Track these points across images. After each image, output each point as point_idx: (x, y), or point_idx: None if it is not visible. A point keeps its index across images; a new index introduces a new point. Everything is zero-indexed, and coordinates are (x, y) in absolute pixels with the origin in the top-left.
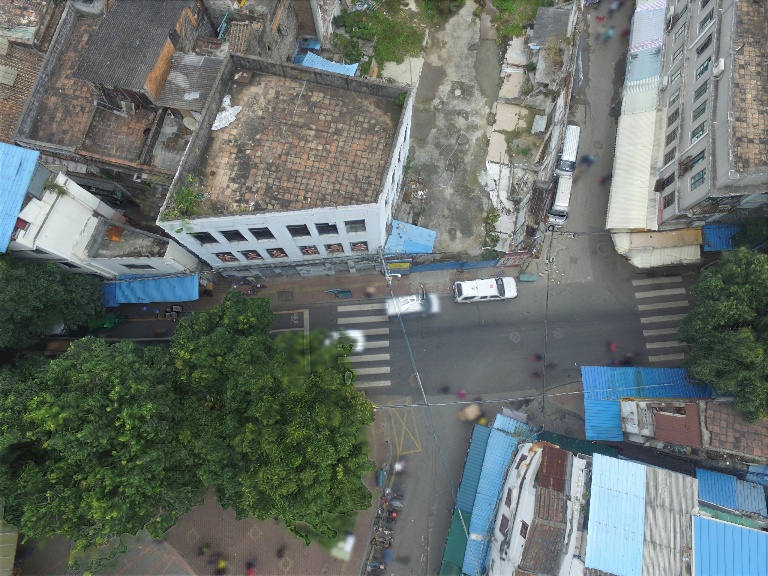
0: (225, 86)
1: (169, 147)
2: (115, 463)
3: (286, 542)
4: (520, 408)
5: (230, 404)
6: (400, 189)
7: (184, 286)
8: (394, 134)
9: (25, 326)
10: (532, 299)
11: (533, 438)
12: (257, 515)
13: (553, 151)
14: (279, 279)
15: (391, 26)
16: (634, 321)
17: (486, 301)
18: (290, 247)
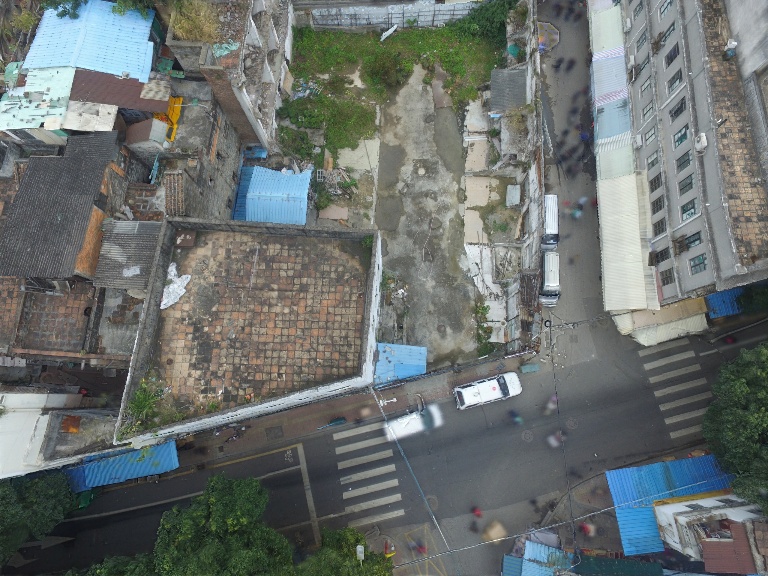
0: (167, 255)
1: (116, 323)
2: None
3: None
4: (546, 514)
5: None
6: (380, 306)
7: (161, 455)
8: (366, 280)
9: None
10: (538, 390)
11: (569, 566)
12: None
13: (535, 233)
14: None
15: (339, 109)
16: (648, 396)
17: None
18: None
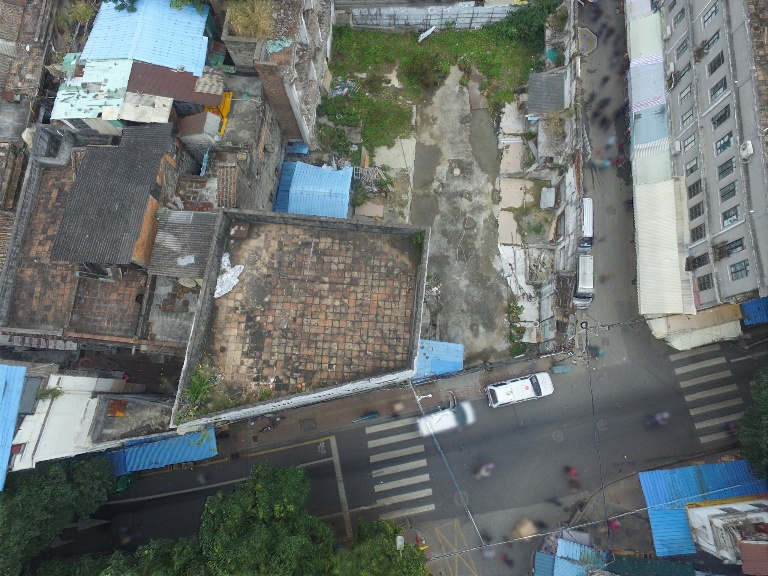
0: (222, 245)
1: (166, 310)
2: None
3: None
4: (575, 514)
5: None
6: None
7: None
8: (416, 276)
9: None
10: (569, 390)
11: (602, 564)
12: None
13: (571, 235)
14: None
15: (376, 108)
16: (678, 400)
17: None
18: None
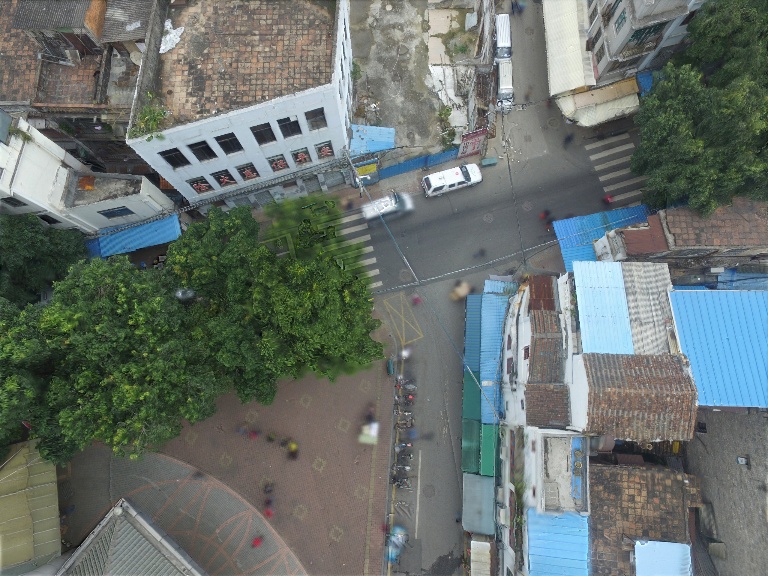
0: (163, 10)
1: (122, 86)
2: (137, 361)
3: (315, 445)
4: None
5: (233, 296)
6: (352, 96)
7: (165, 228)
8: None
9: (19, 283)
10: (497, 181)
11: None
12: (280, 371)
13: (488, 36)
14: (256, 211)
15: None
16: (593, 181)
17: (455, 191)
18: (259, 160)
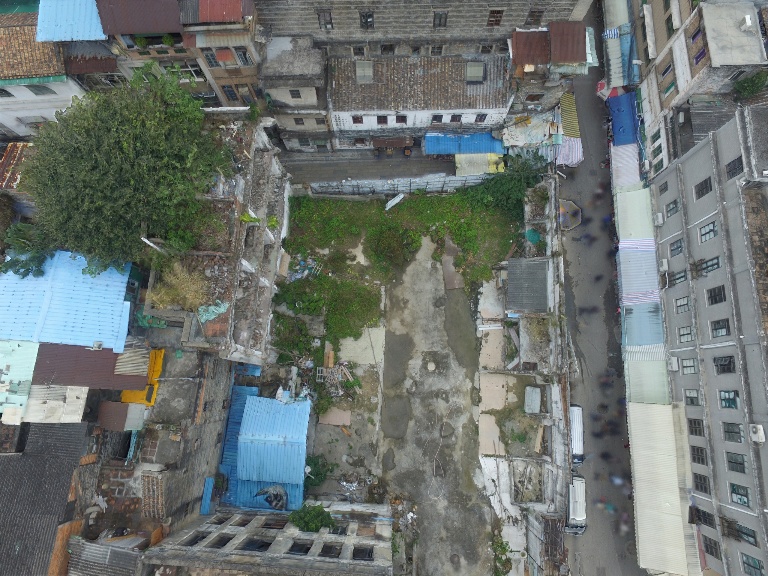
0: None
1: None
2: None
3: None
4: None
5: None
6: None
7: None
8: None
9: None
10: None
11: None
12: None
13: (560, 470)
14: None
15: (340, 292)
16: None
17: None
18: None
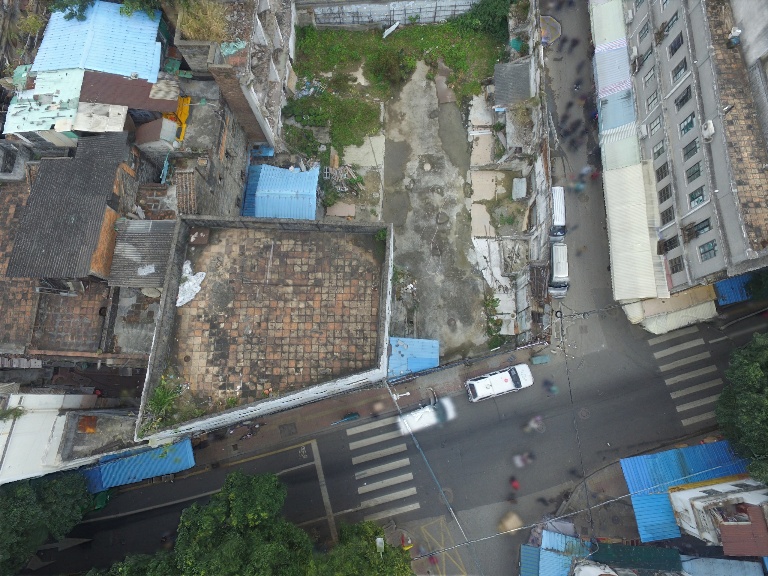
0: (182, 253)
1: (131, 322)
2: None
3: None
4: (561, 504)
5: None
6: (391, 300)
7: (176, 454)
8: (380, 273)
9: None
10: (549, 381)
11: (587, 554)
12: None
13: (543, 225)
14: None
15: (343, 107)
16: (659, 385)
17: None
18: (287, 403)
